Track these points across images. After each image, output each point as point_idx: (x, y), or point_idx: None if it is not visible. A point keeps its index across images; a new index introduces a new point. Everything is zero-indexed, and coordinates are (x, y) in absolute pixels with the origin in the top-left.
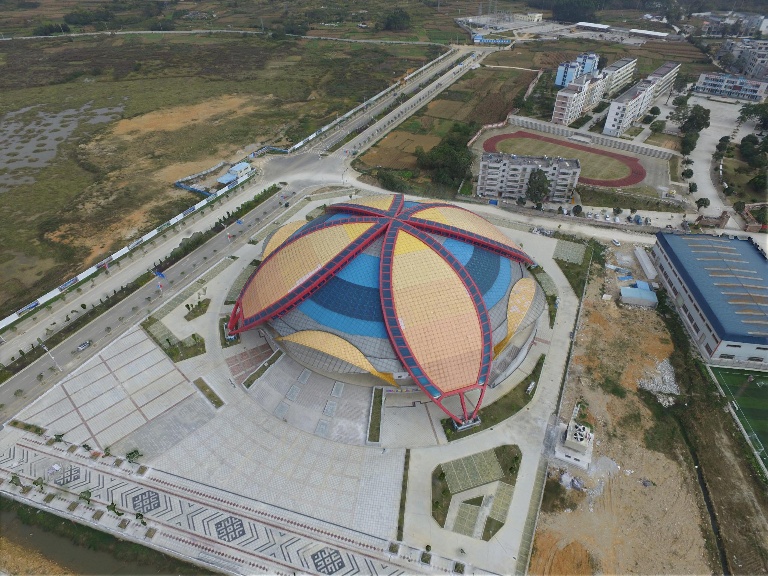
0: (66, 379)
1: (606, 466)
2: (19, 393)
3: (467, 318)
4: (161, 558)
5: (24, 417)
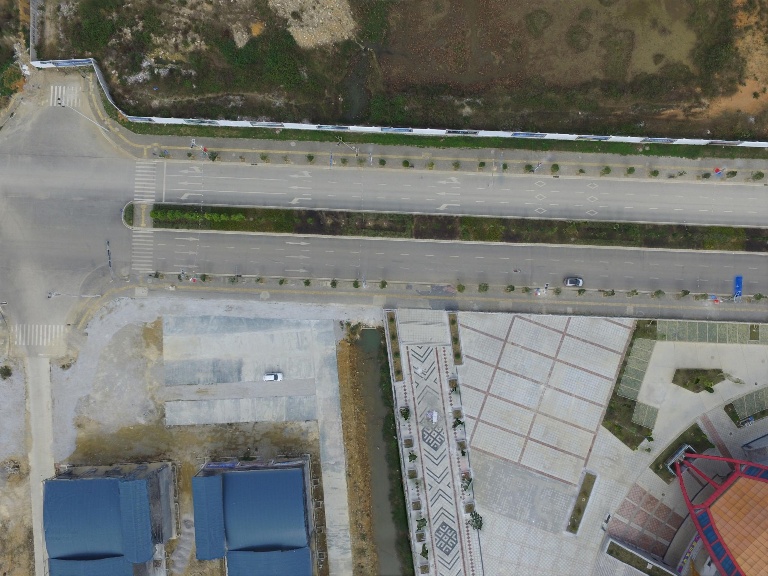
0: (523, 314)
1: None
2: (483, 291)
3: None
4: None
5: (463, 320)
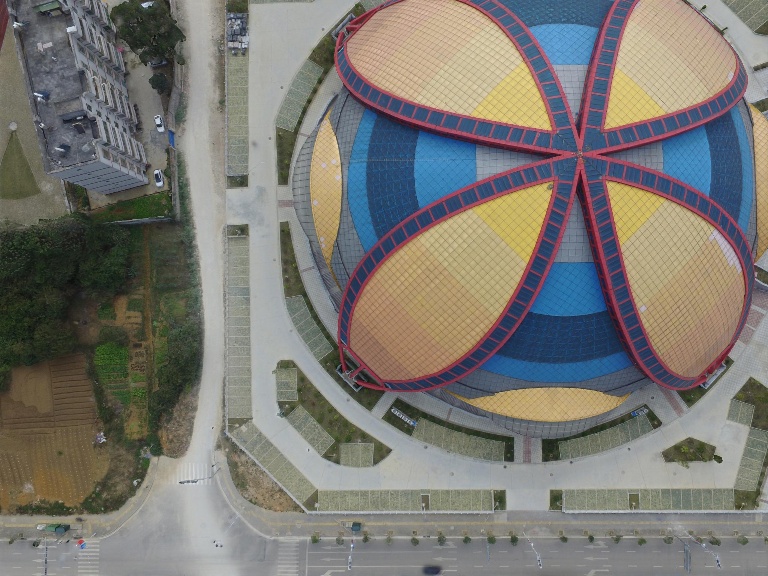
0: None
1: None
2: None
3: (664, 3)
4: None
5: None
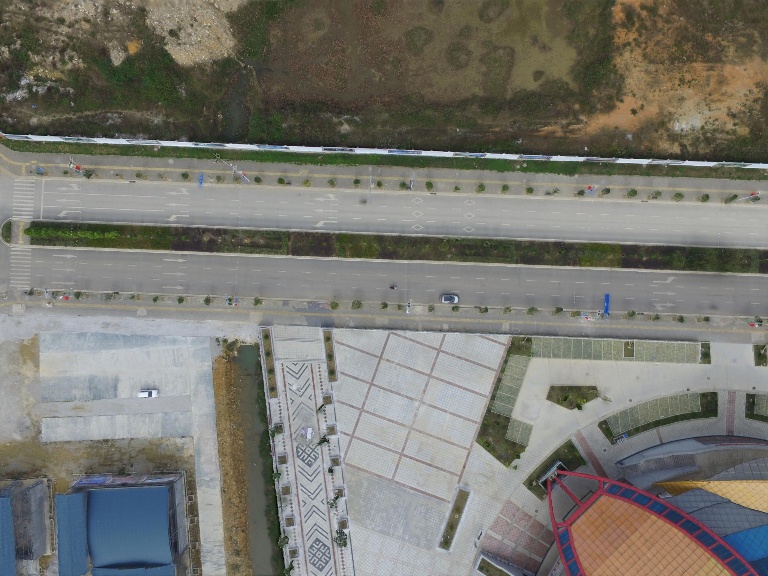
0: (398, 331)
1: None
2: (356, 308)
3: None
4: None
5: (338, 337)
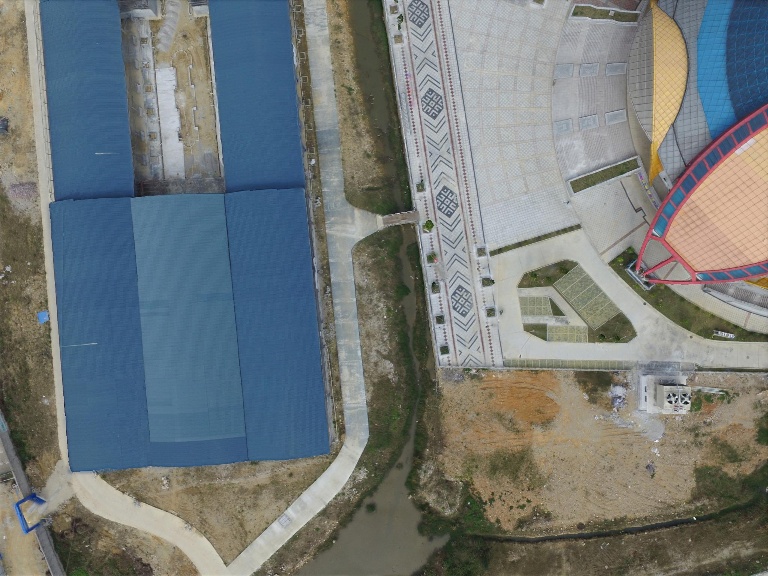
0: None
1: (653, 428)
2: None
3: None
4: (387, 64)
5: None
